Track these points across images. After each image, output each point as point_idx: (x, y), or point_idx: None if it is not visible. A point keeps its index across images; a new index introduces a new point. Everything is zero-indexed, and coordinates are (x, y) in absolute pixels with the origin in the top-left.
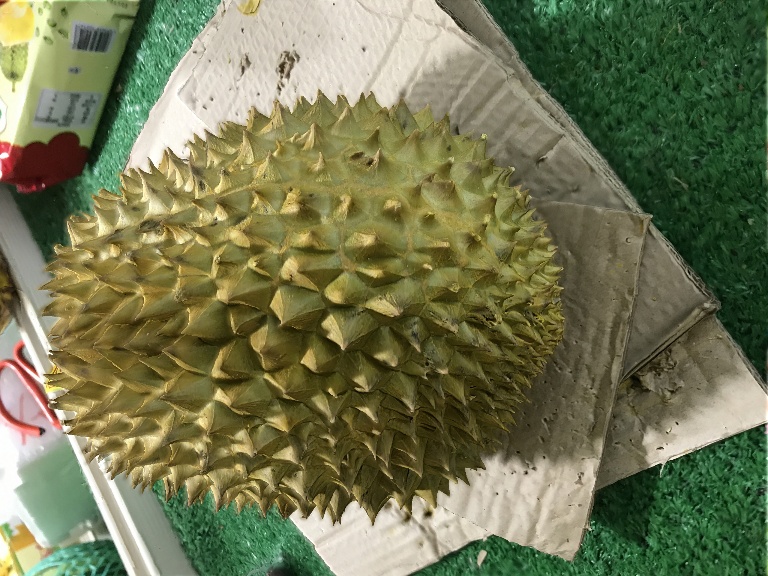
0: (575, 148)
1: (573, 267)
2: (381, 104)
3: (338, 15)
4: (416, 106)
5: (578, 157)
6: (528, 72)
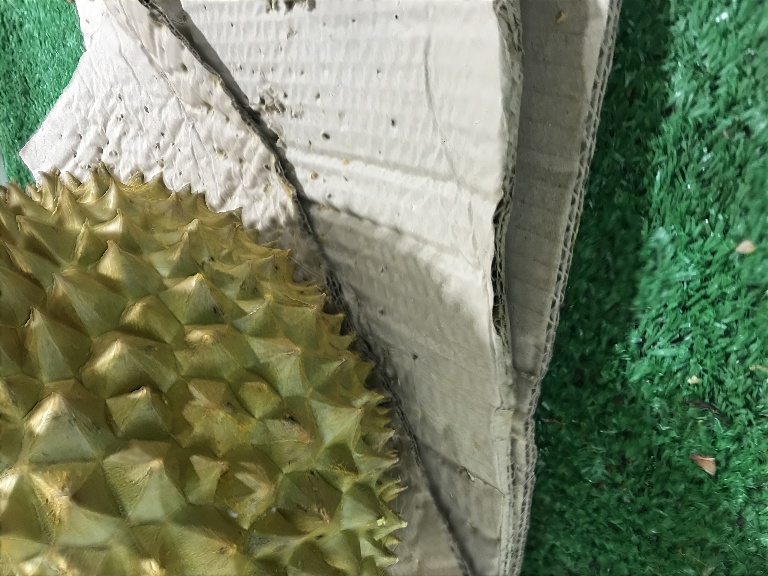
0: (502, 515)
1: (411, 569)
2: (370, 200)
3: (392, 39)
4: (397, 273)
5: (497, 522)
6: (533, 408)
